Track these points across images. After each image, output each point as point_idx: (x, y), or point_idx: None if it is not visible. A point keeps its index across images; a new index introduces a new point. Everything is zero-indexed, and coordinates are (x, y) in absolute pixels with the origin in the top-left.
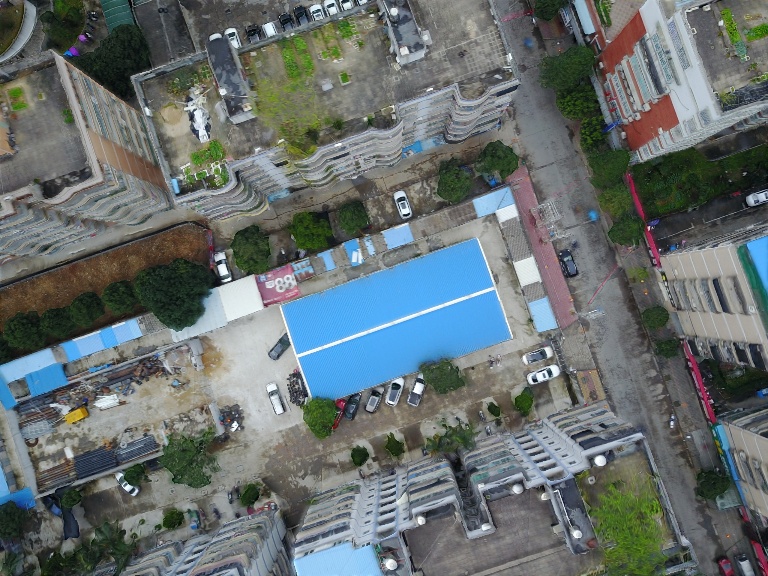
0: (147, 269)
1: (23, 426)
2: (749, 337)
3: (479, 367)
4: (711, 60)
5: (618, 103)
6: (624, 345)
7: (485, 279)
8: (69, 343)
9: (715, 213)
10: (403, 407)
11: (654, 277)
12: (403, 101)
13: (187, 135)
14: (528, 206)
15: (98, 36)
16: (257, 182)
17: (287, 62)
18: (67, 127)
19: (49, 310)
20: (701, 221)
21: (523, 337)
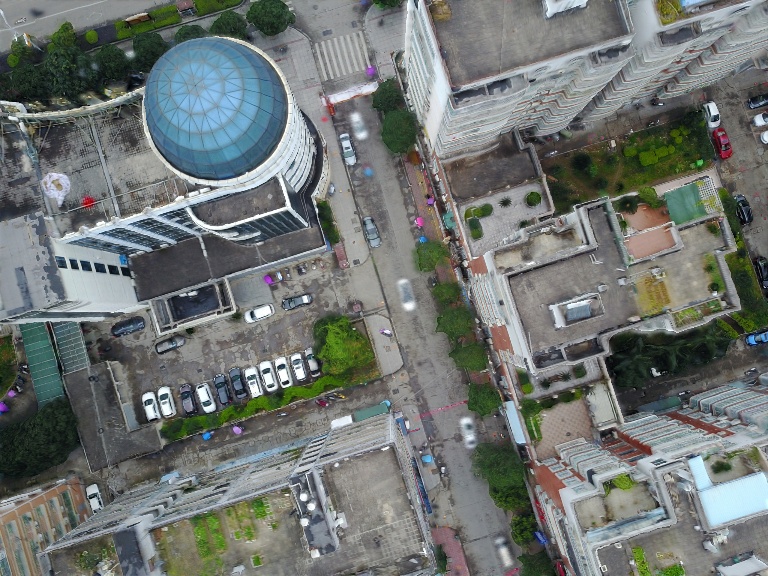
0: None
1: None
2: None
3: None
4: None
5: None
6: None
7: None
8: None
9: None
10: None
11: None
12: None
13: None
14: None
15: (29, 388)
16: None
17: (198, 542)
18: None
19: None
20: None
21: None
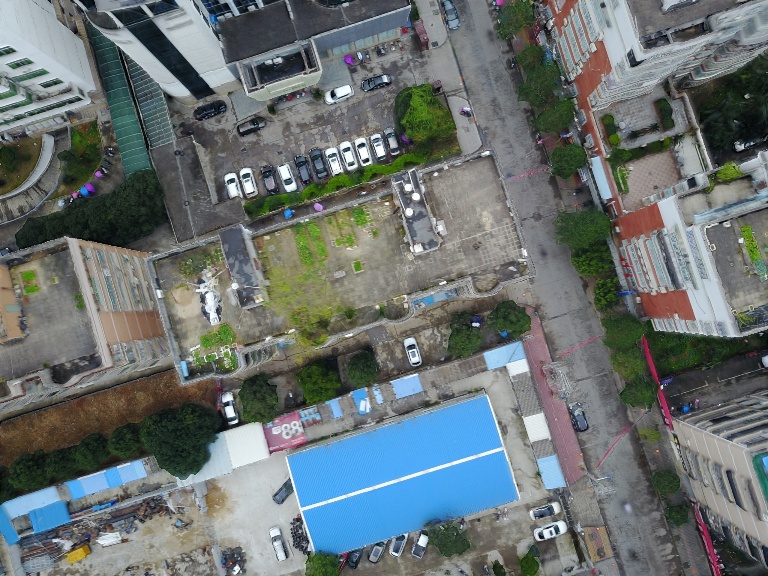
0: (154, 416)
1: (25, 560)
2: (763, 539)
3: (485, 519)
4: (730, 277)
5: (634, 271)
6: (634, 502)
7: (494, 438)
8: (74, 481)
9: (730, 372)
10: (407, 557)
11: (666, 435)
12: (416, 290)
13: (198, 317)
14: (539, 357)
15: (114, 171)
16: None
17: (300, 248)
18: (79, 312)
19: (55, 454)
20: (715, 379)
21: (531, 490)
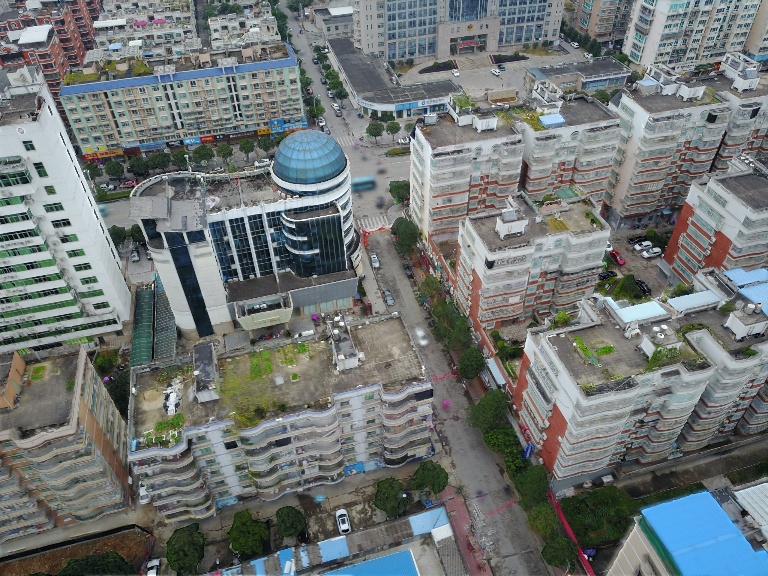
0: None
1: None
2: None
3: None
4: (572, 366)
5: (530, 432)
6: None
7: None
8: None
9: None
10: None
11: None
12: None
13: (158, 410)
14: (465, 532)
15: None
16: (208, 469)
17: (253, 365)
18: (66, 393)
19: None
20: None
21: None
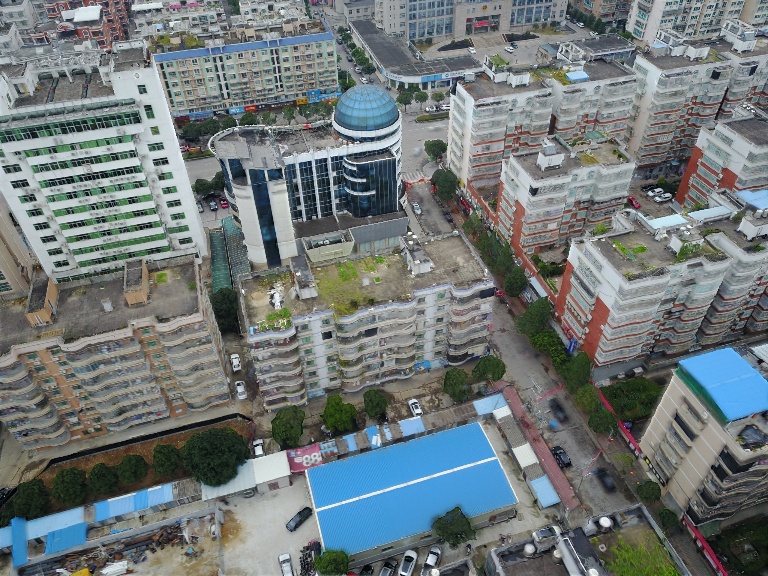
0: None
1: None
2: (717, 449)
3: (491, 546)
4: (614, 261)
5: (573, 330)
6: None
7: (488, 451)
8: (103, 503)
9: None
10: None
11: (641, 468)
12: None
13: (266, 306)
14: (520, 414)
15: None
16: (305, 359)
17: (340, 272)
18: (189, 292)
19: (102, 463)
20: None
21: (531, 518)
